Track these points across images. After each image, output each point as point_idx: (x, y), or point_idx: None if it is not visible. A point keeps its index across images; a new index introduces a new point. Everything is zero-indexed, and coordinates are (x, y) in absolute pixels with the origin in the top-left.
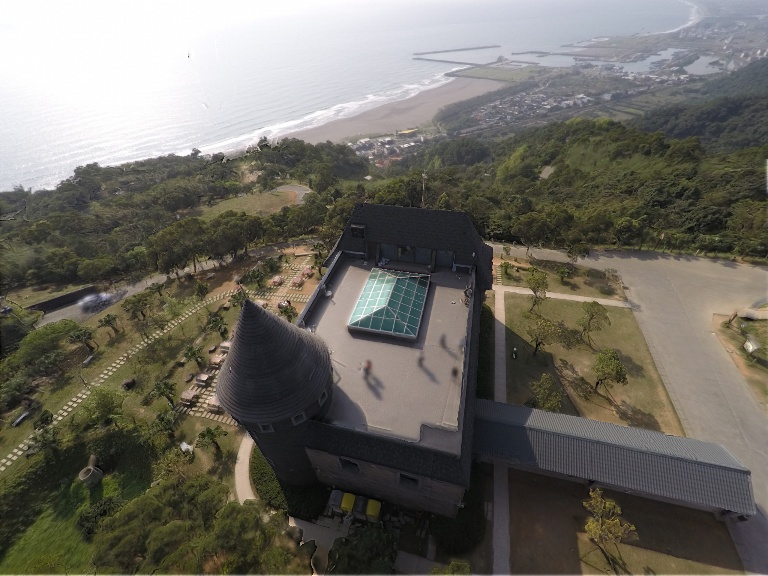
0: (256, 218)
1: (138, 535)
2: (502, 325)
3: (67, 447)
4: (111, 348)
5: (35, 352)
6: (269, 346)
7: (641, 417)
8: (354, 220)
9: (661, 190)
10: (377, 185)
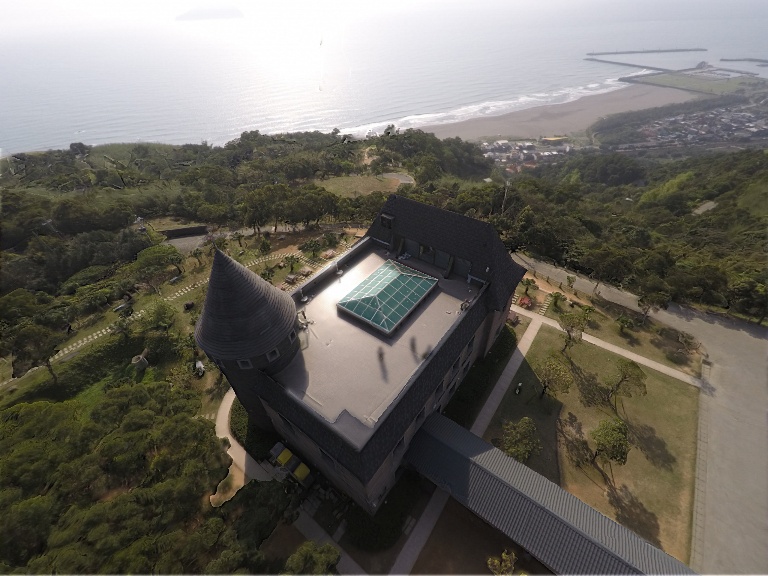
0: (331, 195)
1: (120, 408)
2: (521, 356)
3: (134, 337)
4: (191, 275)
5: (144, 263)
6: (228, 294)
7: (639, 512)
8: (386, 210)
9: None
10: (471, 186)
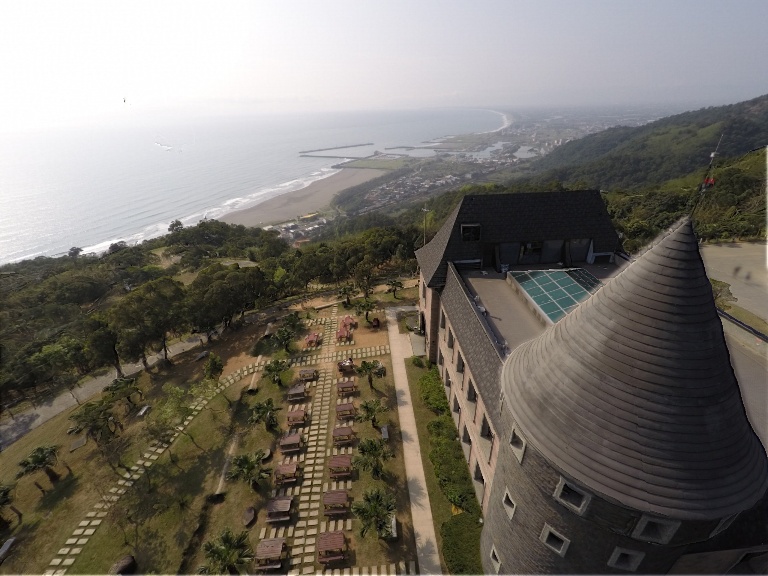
0: None
1: None
2: None
3: None
4: (53, 511)
5: None
6: None
7: None
8: (463, 219)
9: None
10: (347, 239)
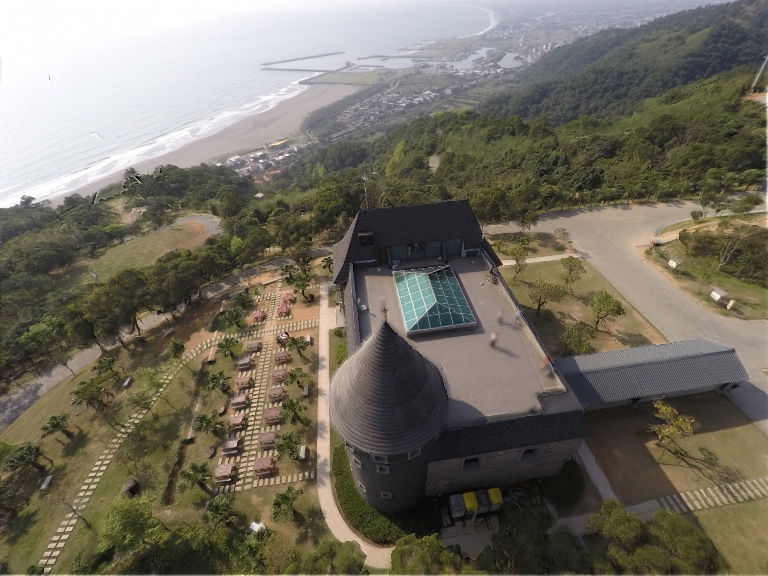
0: (206, 254)
1: None
2: None
3: None
4: (74, 457)
5: None
6: (410, 365)
7: (635, 338)
8: (359, 228)
9: (542, 161)
10: (301, 197)
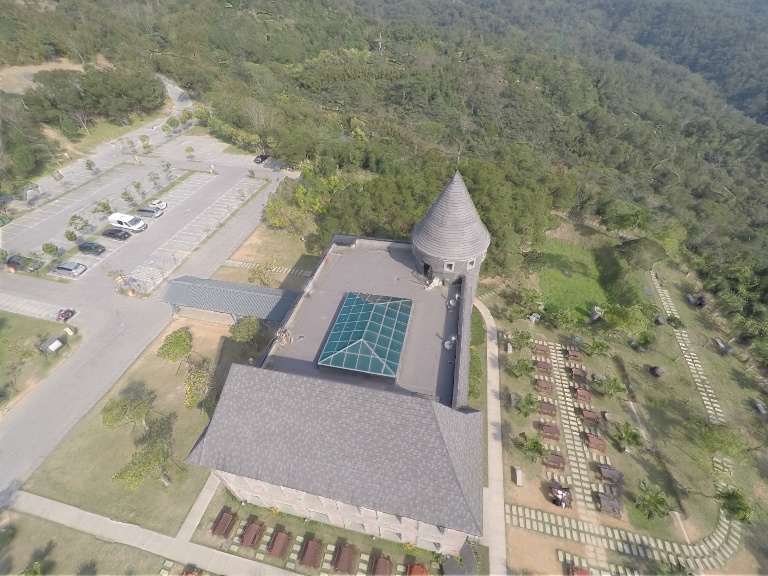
0: None
1: None
2: None
3: None
4: None
5: None
6: None
7: None
8: None
9: None
10: None
